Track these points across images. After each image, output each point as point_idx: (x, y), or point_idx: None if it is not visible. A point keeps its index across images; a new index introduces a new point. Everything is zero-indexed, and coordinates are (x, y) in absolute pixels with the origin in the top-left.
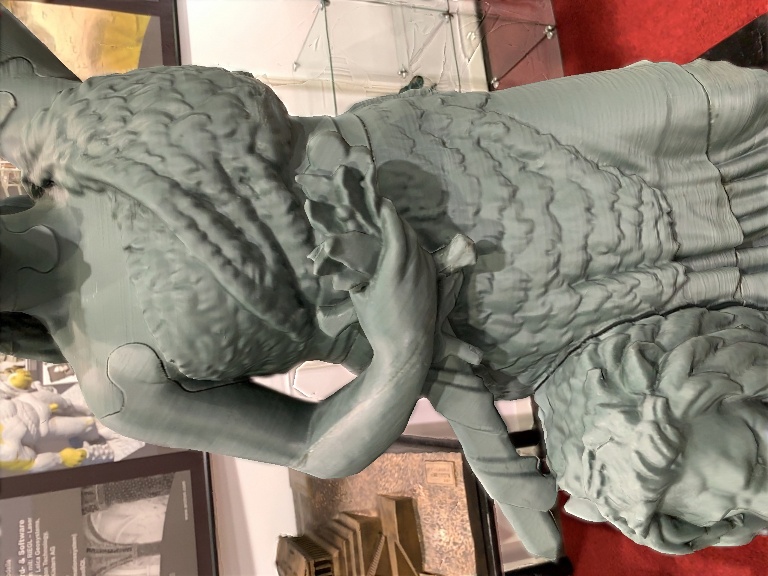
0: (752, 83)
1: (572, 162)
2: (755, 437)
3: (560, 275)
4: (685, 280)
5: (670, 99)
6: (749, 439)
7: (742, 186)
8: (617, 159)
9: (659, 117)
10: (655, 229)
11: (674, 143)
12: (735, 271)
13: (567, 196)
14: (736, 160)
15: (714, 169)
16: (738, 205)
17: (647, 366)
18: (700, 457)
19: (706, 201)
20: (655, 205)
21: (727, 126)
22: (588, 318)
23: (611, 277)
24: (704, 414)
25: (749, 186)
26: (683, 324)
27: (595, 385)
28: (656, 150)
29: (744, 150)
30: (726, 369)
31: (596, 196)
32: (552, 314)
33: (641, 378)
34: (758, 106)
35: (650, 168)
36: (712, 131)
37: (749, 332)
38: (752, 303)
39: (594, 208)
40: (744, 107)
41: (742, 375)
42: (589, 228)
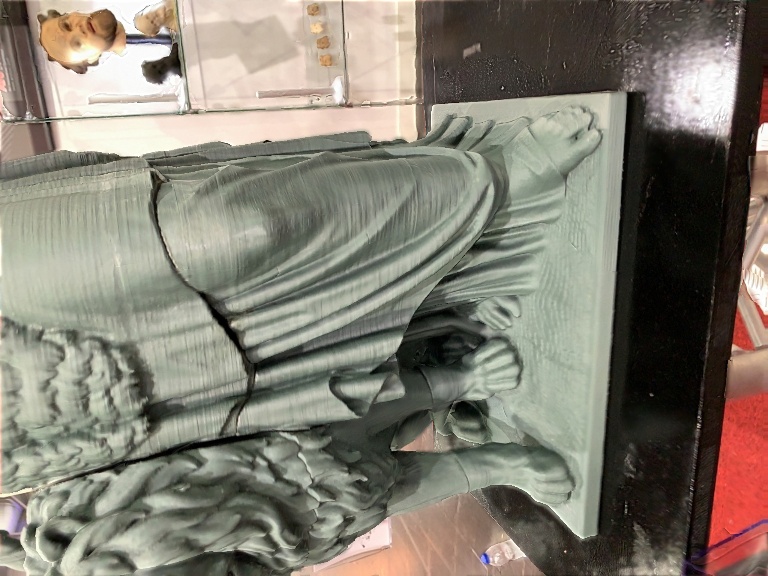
0: (236, 239)
1: None
2: None
3: None
4: (145, 437)
5: (118, 269)
6: None
7: (255, 320)
8: (66, 326)
9: (105, 288)
10: (105, 398)
11: (142, 302)
12: (222, 413)
13: None
14: (253, 291)
15: (205, 317)
16: (254, 335)
17: (47, 548)
18: None
19: (196, 347)
20: (106, 375)
21: (211, 280)
22: (30, 479)
23: (56, 442)
24: None
25: (266, 318)
26: (123, 488)
27: (22, 544)
28: (118, 311)
29: (264, 280)
30: (126, 550)
31: (26, 376)
32: None
33: (42, 556)
34: (250, 258)
35: (113, 328)
36: (193, 285)
37: (181, 500)
38: (248, 433)
39: (22, 389)
40: (225, 265)
41: (140, 555)
42: (14, 410)
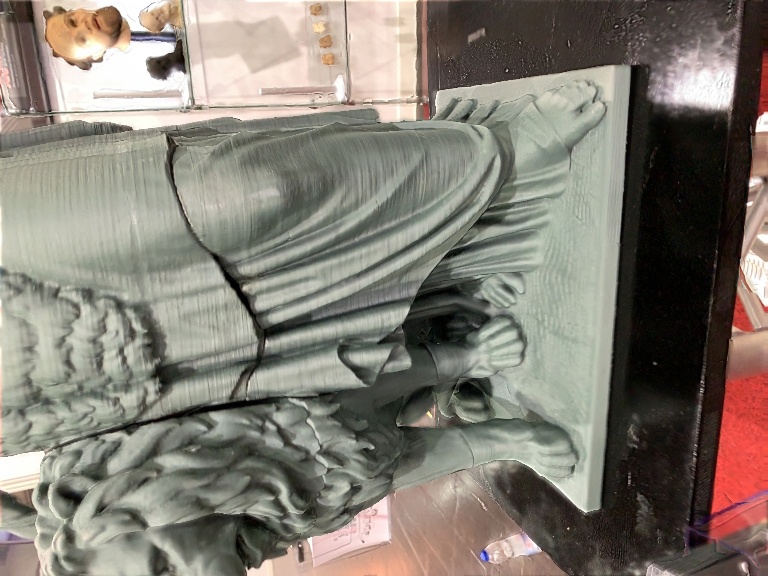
0: (250, 199)
1: (11, 299)
2: (163, 555)
3: (2, 407)
4: (157, 398)
5: (134, 226)
6: (144, 565)
7: (267, 284)
8: (81, 283)
9: (121, 246)
10: (119, 357)
11: (156, 262)
12: (232, 377)
13: (4, 335)
14: (265, 255)
15: (217, 279)
16: (264, 300)
17: (60, 504)
18: (103, 573)
19: (208, 309)
20: (120, 333)
21: (225, 241)
22: (43, 438)
23: (69, 401)
24: (110, 543)
25: (277, 282)
26: (135, 447)
27: (34, 502)
28: (133, 270)
29: (276, 244)
30: (138, 507)
31: (41, 332)
32: (1, 437)
33: (55, 513)
34: (264, 219)
35: (128, 288)
36: (207, 246)
37: (192, 460)
38: (257, 398)
39: (37, 345)
40: (239, 225)
41: (151, 513)
42: (29, 367)
